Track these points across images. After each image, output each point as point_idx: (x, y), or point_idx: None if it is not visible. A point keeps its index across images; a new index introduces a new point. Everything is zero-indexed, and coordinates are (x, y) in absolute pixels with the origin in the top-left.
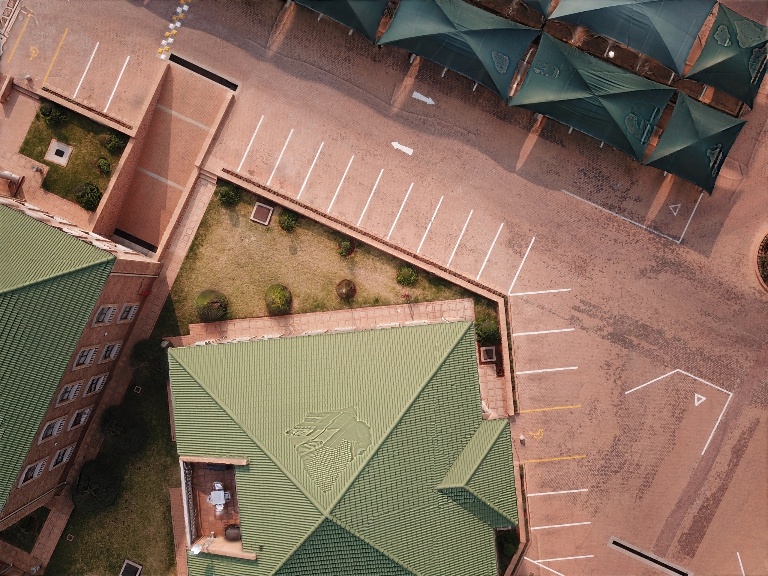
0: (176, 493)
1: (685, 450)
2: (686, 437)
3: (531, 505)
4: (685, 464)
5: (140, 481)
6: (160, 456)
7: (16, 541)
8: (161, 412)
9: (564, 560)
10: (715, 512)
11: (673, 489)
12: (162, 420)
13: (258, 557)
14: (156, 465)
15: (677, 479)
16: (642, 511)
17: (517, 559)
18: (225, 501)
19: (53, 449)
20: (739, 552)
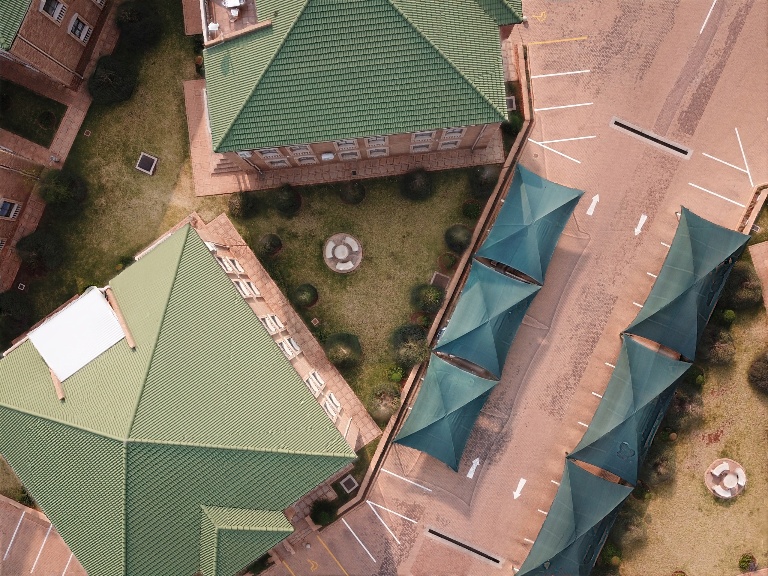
0: (190, 86)
1: (684, 29)
2: (685, 16)
3: (535, 87)
4: (684, 43)
5: (155, 75)
6: (174, 50)
7: (35, 137)
8: (175, 7)
9: (567, 141)
10: (713, 89)
11: (672, 68)
12: (176, 15)
13: (273, 24)
14: (170, 59)
15: (676, 58)
16: (643, 91)
17: (522, 137)
18: (240, 4)
19: (72, 5)
20: (737, 127)
